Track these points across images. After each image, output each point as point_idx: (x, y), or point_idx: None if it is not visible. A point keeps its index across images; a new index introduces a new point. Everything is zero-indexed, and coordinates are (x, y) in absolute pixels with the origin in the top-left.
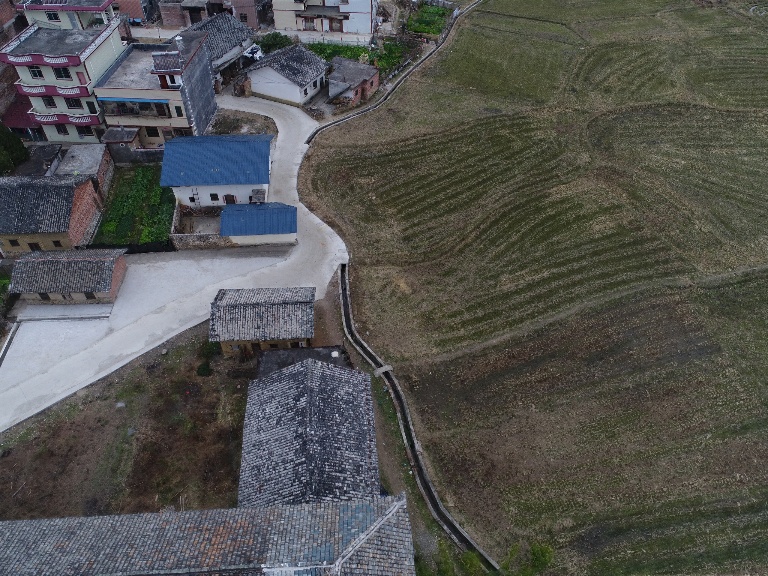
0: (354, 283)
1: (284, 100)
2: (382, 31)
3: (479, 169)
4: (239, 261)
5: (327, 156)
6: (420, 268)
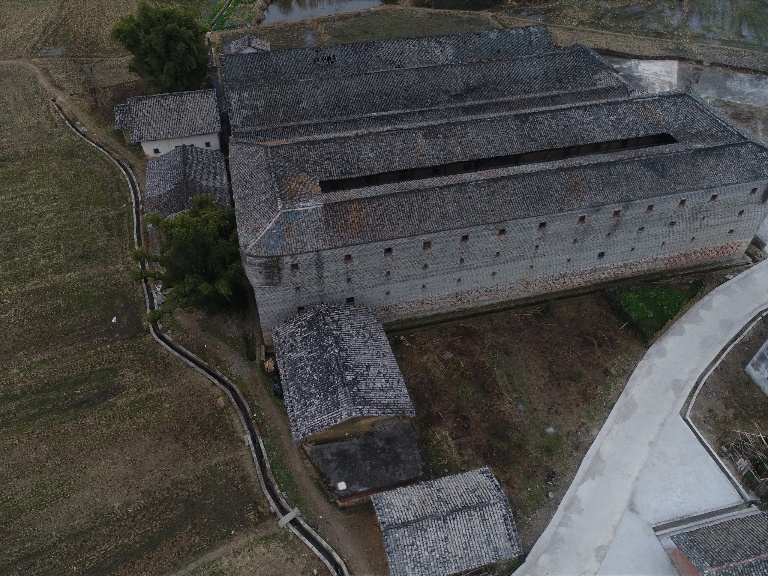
0: None
1: None
2: None
3: None
4: None
5: None
6: None
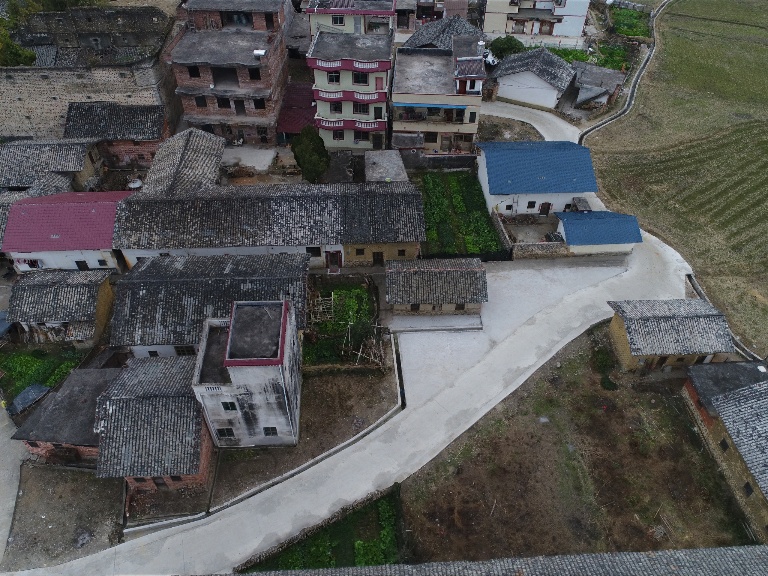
0: (709, 294)
1: (534, 105)
2: (596, 34)
3: (765, 176)
4: (581, 271)
5: (604, 162)
6: (765, 278)
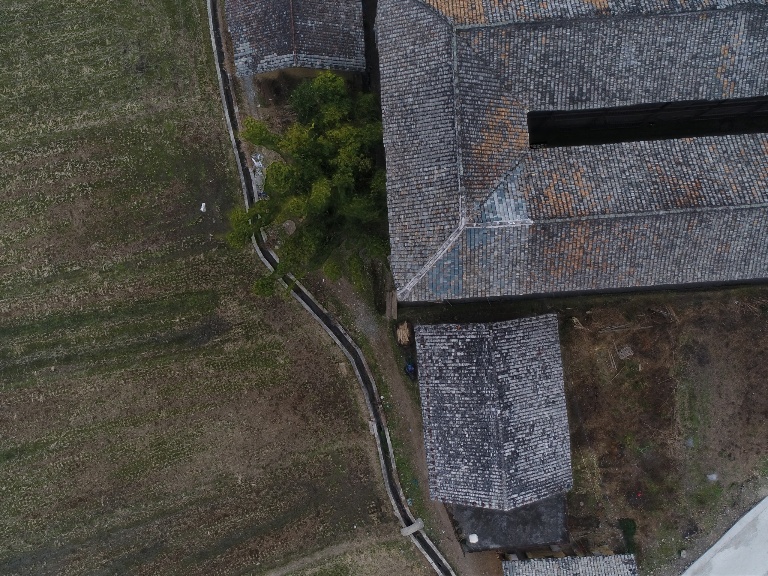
0: None
1: None
2: None
3: None
4: None
5: None
6: None
